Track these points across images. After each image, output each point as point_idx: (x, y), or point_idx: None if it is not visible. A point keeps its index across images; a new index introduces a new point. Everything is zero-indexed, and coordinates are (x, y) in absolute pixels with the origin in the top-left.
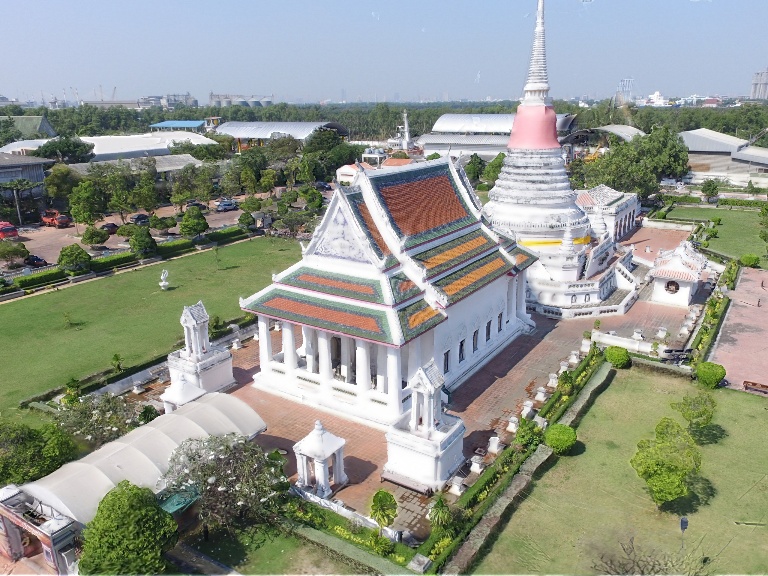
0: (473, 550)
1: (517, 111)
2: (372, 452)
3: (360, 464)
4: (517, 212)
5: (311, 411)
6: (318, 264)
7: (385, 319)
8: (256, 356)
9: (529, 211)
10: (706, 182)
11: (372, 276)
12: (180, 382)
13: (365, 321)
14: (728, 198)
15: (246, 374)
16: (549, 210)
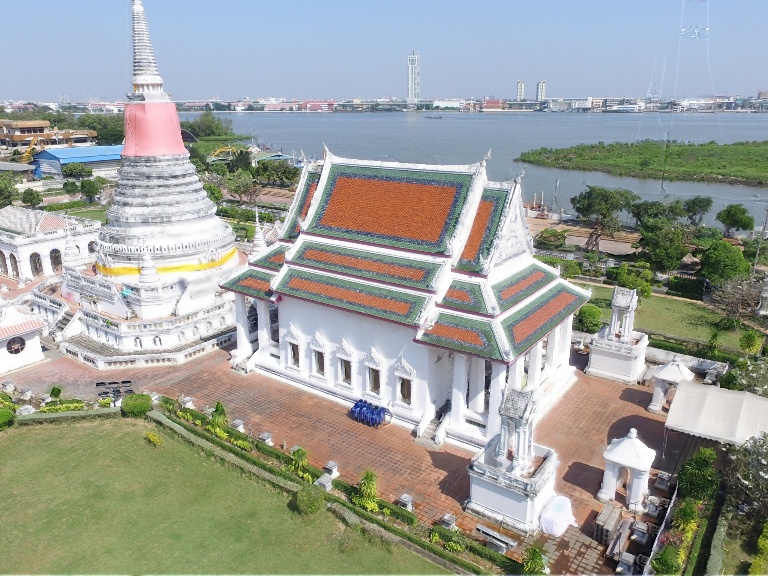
0: (725, 345)
1: (146, 109)
2: (609, 389)
3: (630, 394)
4: (201, 228)
5: (550, 420)
6: (497, 277)
7: (567, 287)
8: (401, 470)
9: (209, 223)
10: (25, 191)
11: (528, 263)
12: (637, 439)
13: (565, 297)
14: (49, 204)
15: (464, 471)
16: (216, 218)
